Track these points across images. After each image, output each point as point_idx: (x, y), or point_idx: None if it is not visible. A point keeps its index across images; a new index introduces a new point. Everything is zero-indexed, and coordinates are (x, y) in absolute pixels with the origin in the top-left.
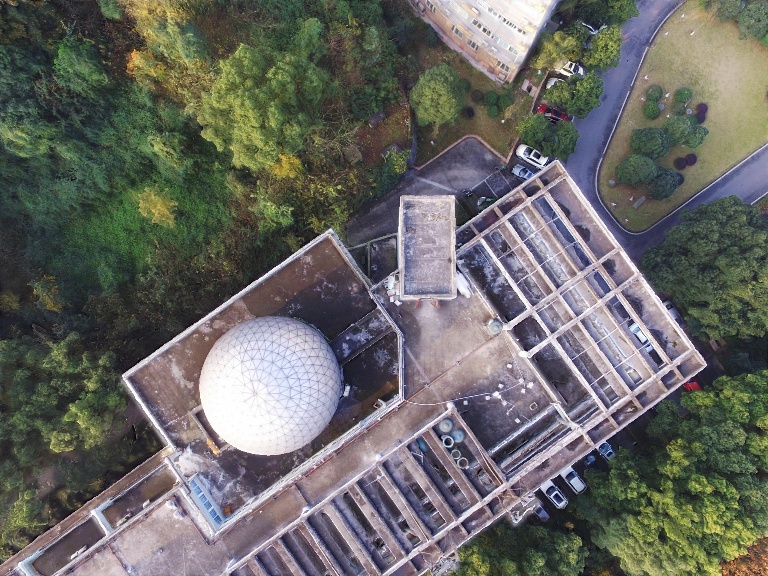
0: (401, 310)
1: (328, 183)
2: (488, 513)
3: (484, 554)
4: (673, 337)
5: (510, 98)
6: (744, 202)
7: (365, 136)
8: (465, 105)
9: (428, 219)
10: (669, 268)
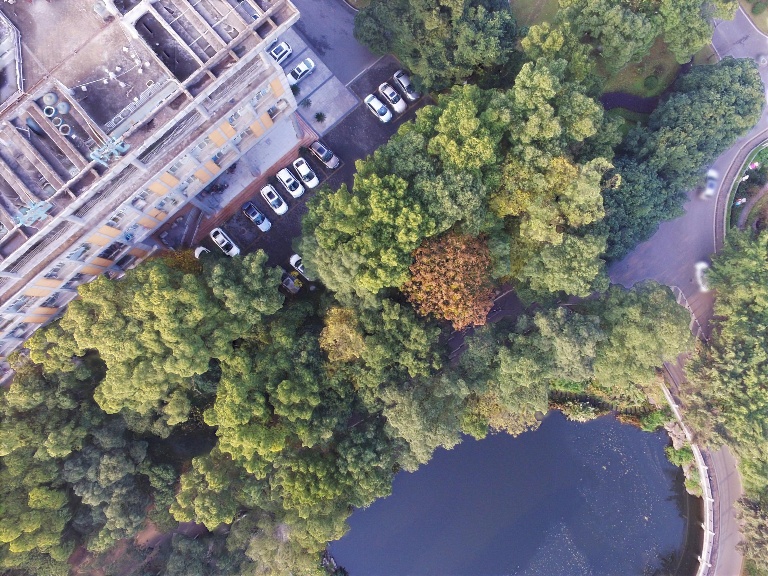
0: (16, 9)
1: None
2: (95, 176)
3: (165, 273)
4: None
5: None
6: None
7: None
8: None
9: None
10: (375, 20)
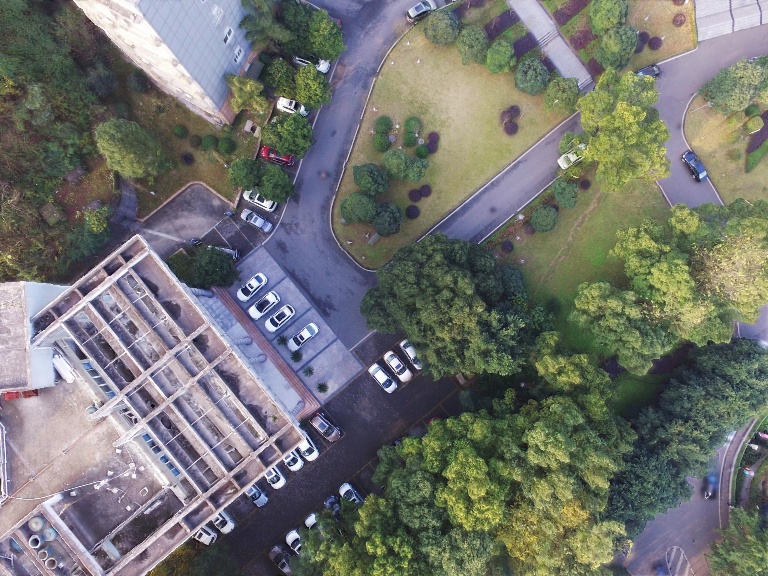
0: (1, 401)
1: (4, 252)
2: None
3: None
4: (273, 411)
5: (232, 141)
6: (485, 230)
7: (68, 194)
8: (184, 152)
9: (0, 308)
10: (384, 310)
